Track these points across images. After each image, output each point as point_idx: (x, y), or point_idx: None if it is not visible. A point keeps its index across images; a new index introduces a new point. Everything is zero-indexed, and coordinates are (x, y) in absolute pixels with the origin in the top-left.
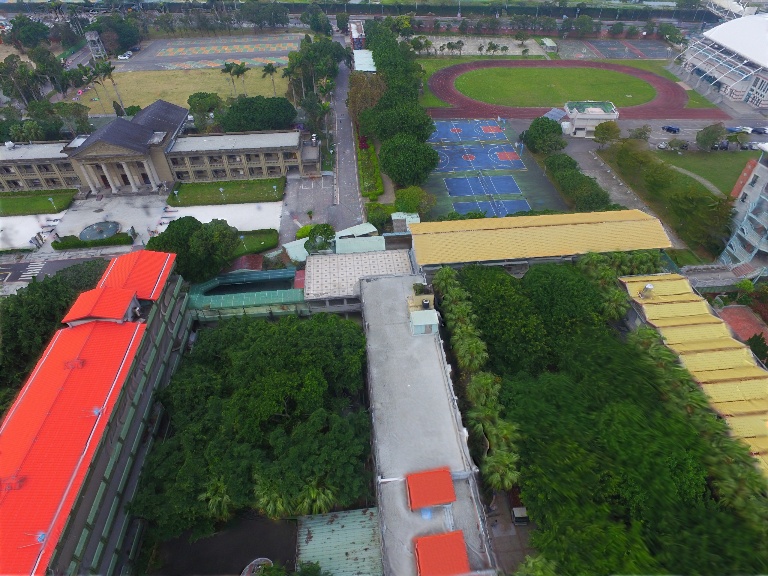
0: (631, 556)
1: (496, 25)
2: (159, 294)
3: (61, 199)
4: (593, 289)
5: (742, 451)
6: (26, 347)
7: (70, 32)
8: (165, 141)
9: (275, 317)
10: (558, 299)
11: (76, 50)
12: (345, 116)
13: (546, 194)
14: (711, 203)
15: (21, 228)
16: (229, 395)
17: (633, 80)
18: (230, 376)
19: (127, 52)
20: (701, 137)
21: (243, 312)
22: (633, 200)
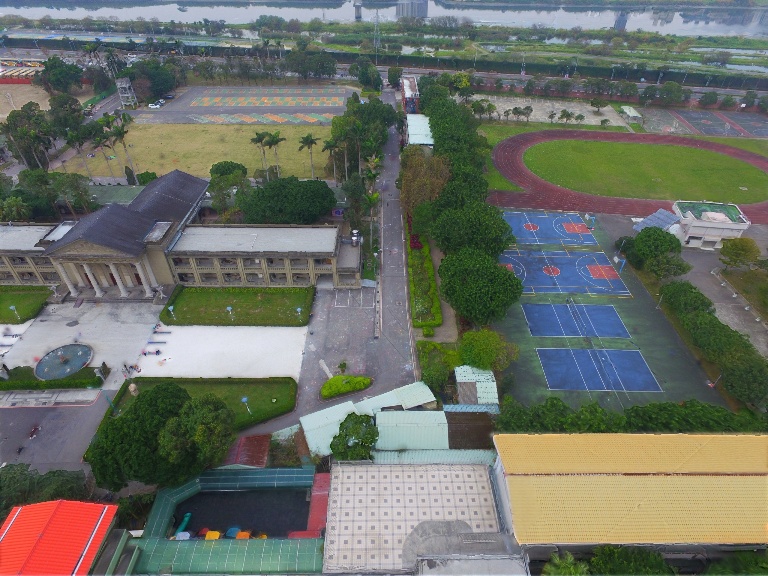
0: None
1: (567, 88)
2: None
3: (32, 300)
4: None
5: None
6: None
7: (103, 76)
8: (167, 237)
9: None
10: None
11: (108, 95)
12: (393, 197)
13: (666, 342)
14: None
15: None
16: None
17: (743, 166)
18: None
19: (159, 100)
20: None
21: None
22: None
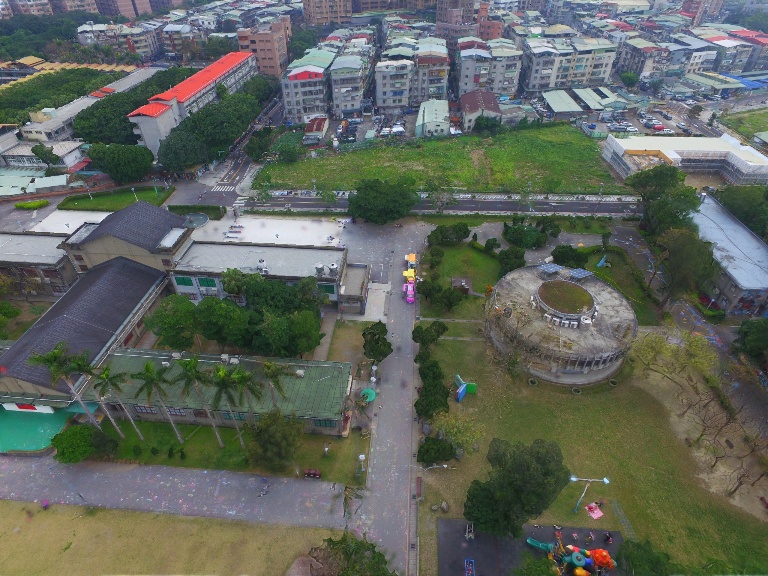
0: None
1: None
2: None
3: None
4: None
5: None
6: None
7: None
8: None
9: None
10: None
11: None
12: None
13: None
14: None
15: (259, 235)
16: None
17: None
18: None
19: None
20: None
21: None
22: None
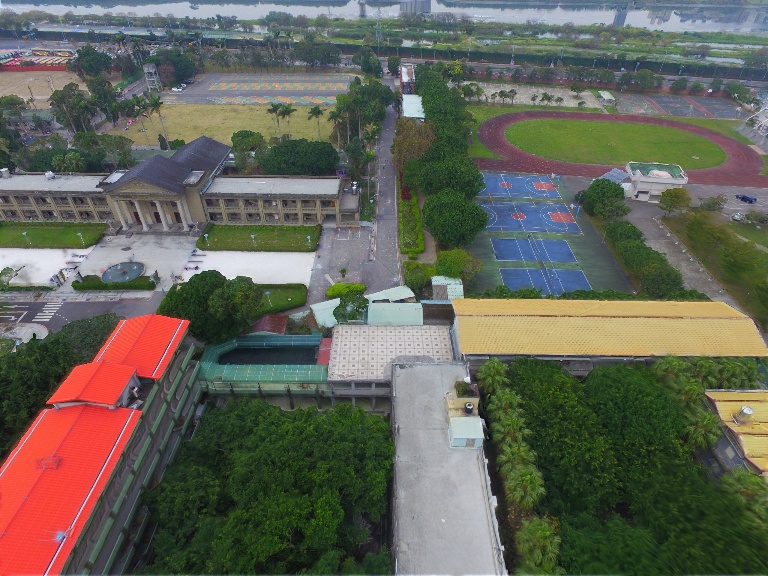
0: None
1: (551, 75)
2: (163, 372)
3: (92, 233)
4: (675, 408)
5: None
6: (10, 420)
7: (130, 63)
8: (201, 181)
9: (293, 395)
10: (632, 419)
11: (134, 80)
12: (389, 162)
13: (605, 265)
14: None
15: (46, 262)
16: (227, 507)
17: (699, 140)
18: (231, 481)
19: (181, 85)
20: None
21: (258, 387)
22: (707, 280)
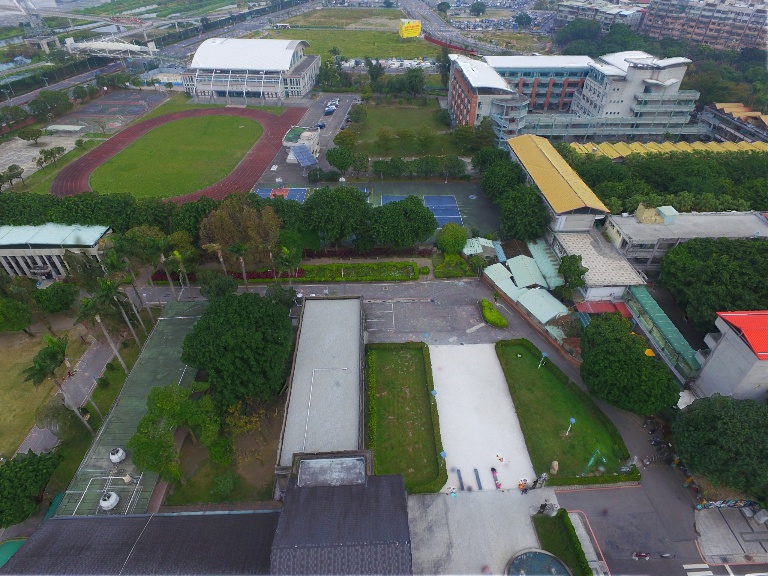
0: (762, 182)
1: None
2: None
3: None
4: None
5: (699, 150)
6: None
7: None
8: None
9: None
10: None
11: None
12: None
13: (414, 187)
14: (476, 127)
15: None
16: None
17: (208, 118)
18: None
19: None
20: (358, 117)
21: None
22: None
